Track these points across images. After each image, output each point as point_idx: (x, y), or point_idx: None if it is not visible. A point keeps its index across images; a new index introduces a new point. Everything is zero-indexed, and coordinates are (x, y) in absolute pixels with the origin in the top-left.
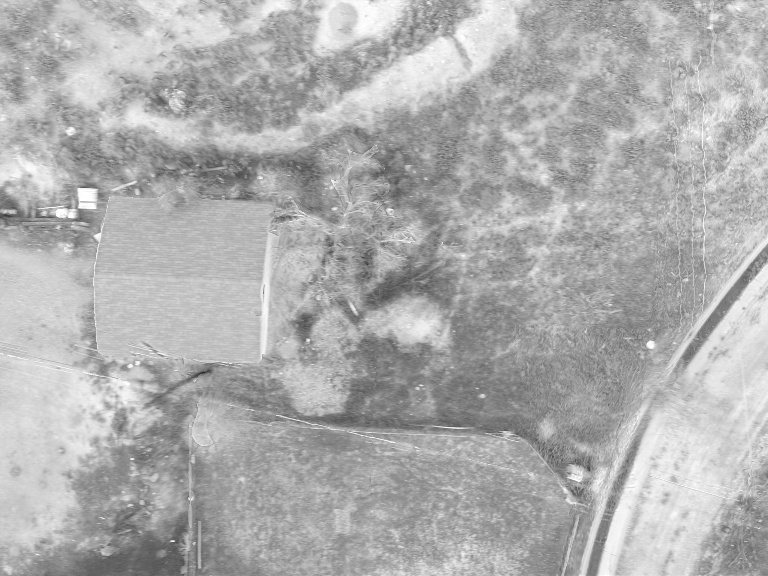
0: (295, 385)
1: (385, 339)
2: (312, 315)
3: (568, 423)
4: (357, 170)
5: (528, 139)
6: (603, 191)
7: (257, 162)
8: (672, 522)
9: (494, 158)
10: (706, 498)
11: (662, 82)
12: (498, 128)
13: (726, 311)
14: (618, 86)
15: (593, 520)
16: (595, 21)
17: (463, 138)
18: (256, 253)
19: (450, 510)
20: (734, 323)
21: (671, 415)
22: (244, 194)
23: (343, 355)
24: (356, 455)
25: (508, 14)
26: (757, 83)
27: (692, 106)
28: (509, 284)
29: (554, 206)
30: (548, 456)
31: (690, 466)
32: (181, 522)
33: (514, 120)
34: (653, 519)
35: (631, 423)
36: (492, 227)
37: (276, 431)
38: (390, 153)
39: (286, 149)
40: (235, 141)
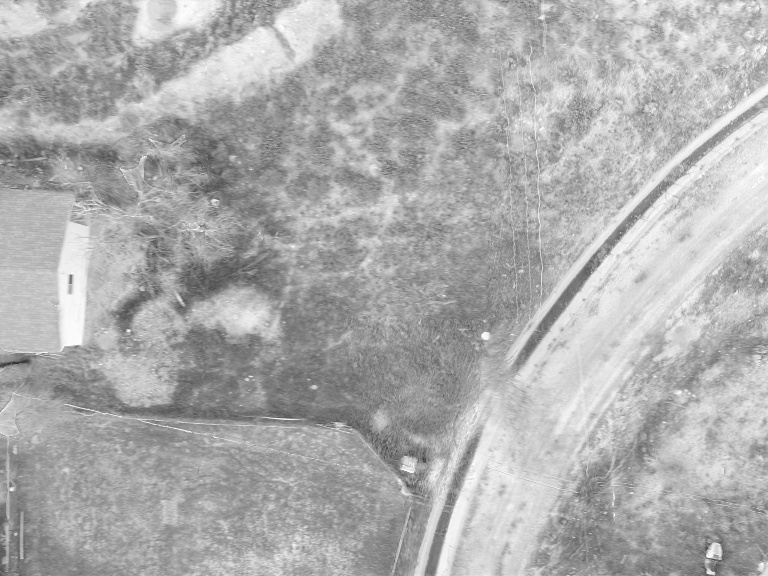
0: (117, 376)
1: (213, 330)
2: (134, 306)
3: (402, 414)
4: (169, 160)
5: (356, 130)
6: (434, 182)
7: (76, 152)
8: (509, 514)
9: (320, 149)
10: (543, 490)
11: (492, 72)
12: (325, 119)
13: (568, 302)
14: (447, 76)
15: (431, 512)
16: (422, 11)
17: (288, 129)
18: (53, 242)
19: (281, 501)
20: (574, 314)
21: (510, 407)
22: (45, 184)
23: (169, 346)
24: (184, 446)
25: (329, 4)
26: (591, 73)
27: (523, 97)
28: (340, 275)
29: (384, 197)
30: (382, 447)
31: (527, 458)
32: (2, 513)
33: (340, 110)
34: (490, 511)
35: (469, 415)
36: (321, 218)
37: (102, 422)
38: (213, 143)
39: (105, 139)
40: (53, 131)
